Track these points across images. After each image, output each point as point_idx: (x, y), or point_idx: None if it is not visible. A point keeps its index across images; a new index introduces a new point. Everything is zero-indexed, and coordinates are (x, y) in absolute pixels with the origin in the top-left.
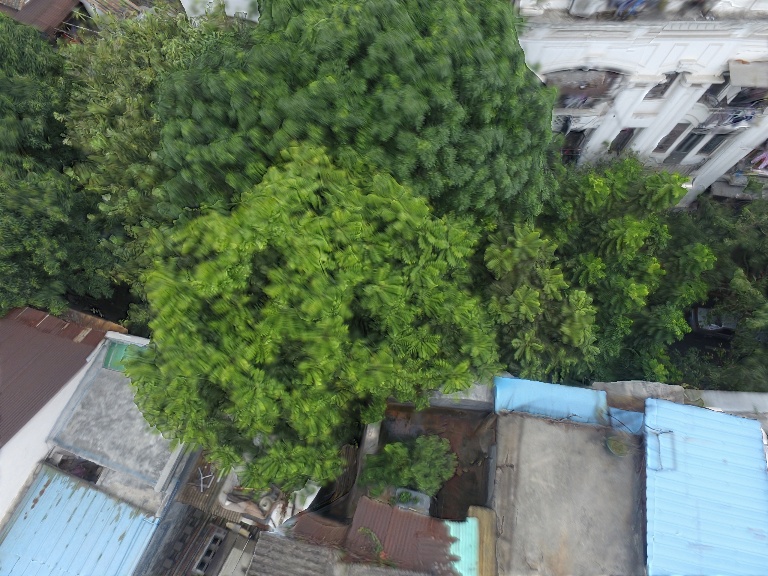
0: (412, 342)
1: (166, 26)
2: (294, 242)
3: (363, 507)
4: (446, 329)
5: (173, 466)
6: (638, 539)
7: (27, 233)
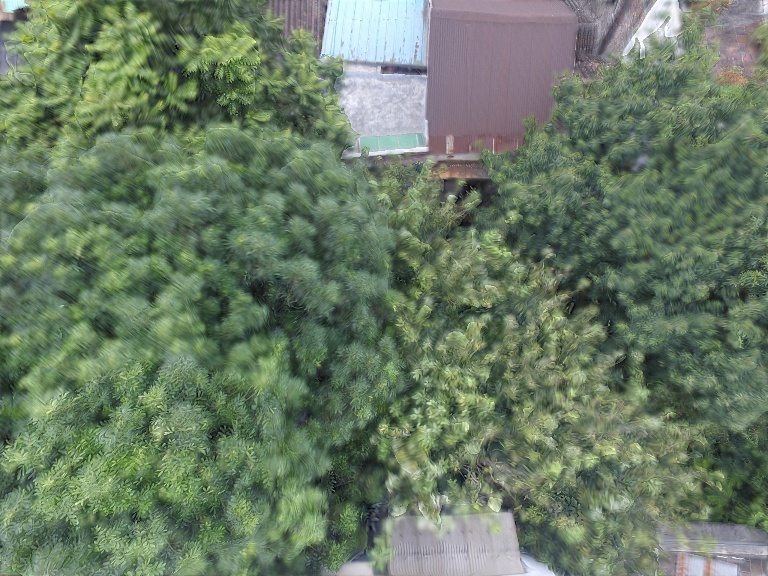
0: None
1: (582, 545)
2: None
3: None
4: None
5: None
6: None
7: None
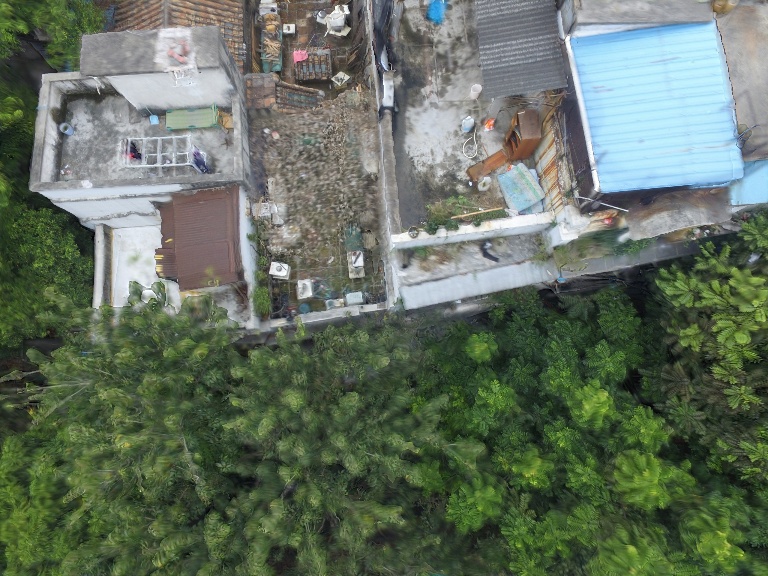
0: None
1: None
2: None
3: None
4: None
5: None
6: None
7: None
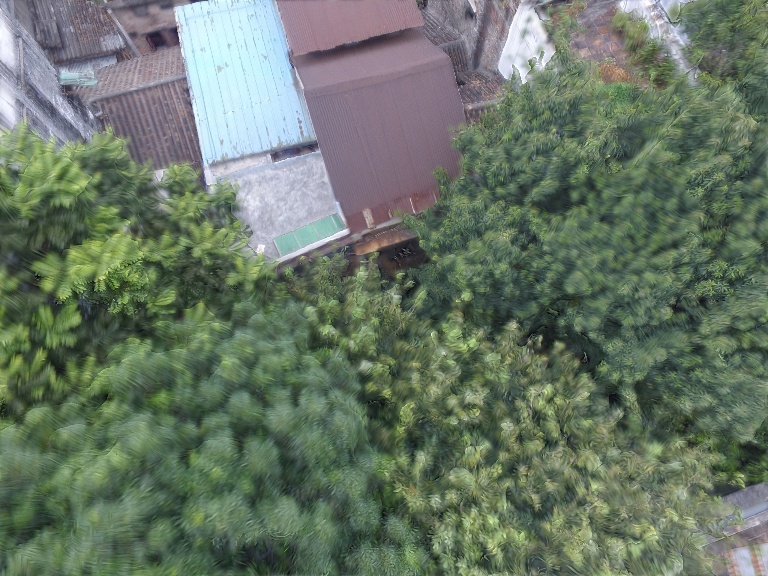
0: None
1: None
2: None
3: None
4: None
5: None
6: None
7: None
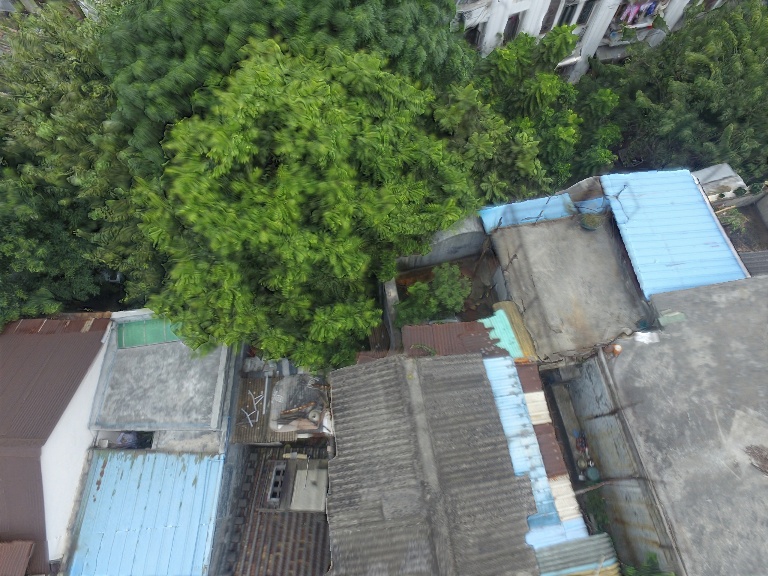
0: (401, 191)
1: None
2: (281, 102)
3: (407, 333)
4: (425, 175)
5: (220, 403)
6: (629, 284)
7: (1, 241)
